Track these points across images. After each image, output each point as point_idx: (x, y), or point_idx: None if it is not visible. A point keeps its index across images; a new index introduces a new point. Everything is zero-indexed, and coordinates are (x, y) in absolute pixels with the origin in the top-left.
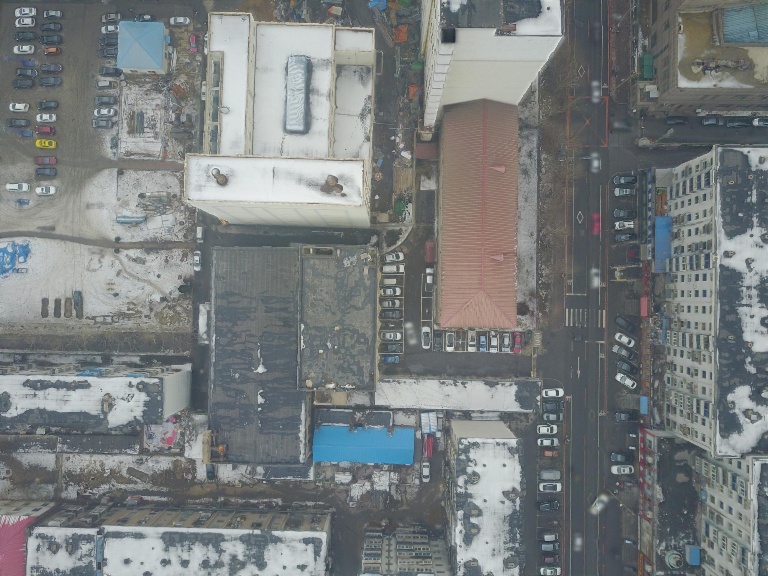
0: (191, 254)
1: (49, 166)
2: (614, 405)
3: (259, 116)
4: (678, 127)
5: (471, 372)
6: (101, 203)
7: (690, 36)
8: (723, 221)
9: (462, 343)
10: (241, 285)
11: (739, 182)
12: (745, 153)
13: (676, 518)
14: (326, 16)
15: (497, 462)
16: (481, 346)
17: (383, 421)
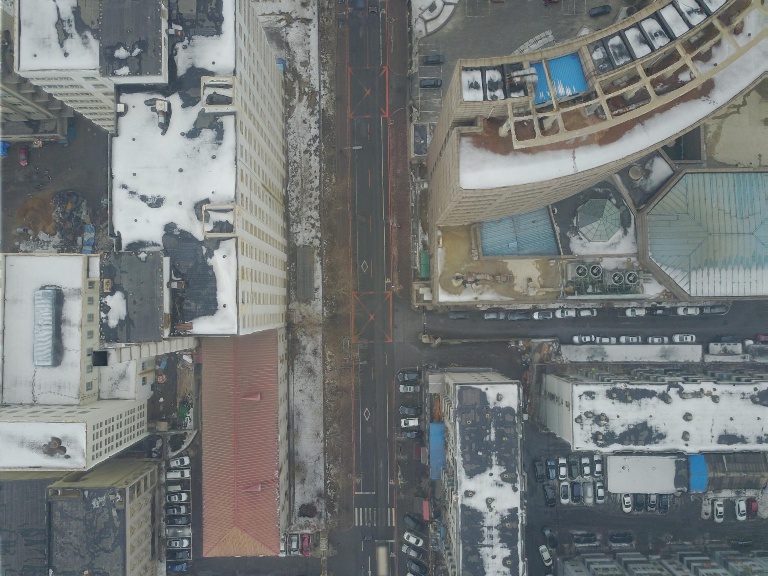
0: None
1: None
2: None
3: (9, 349)
4: (461, 321)
5: None
6: None
7: (450, 249)
8: (463, 460)
9: None
10: (0, 518)
11: (478, 420)
12: (483, 390)
13: None
14: (106, 217)
15: None
16: None
17: None
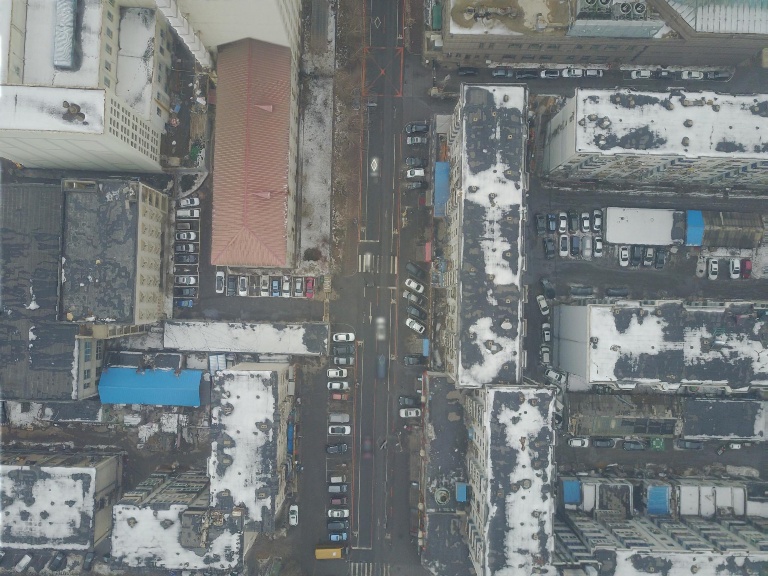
0: None
1: None
2: (403, 350)
3: (30, 53)
4: (470, 78)
5: (265, 317)
6: None
7: None
8: (468, 157)
9: (256, 288)
10: (15, 222)
11: (484, 119)
12: (491, 91)
13: (447, 456)
14: None
15: (250, 394)
16: (274, 291)
17: (172, 363)
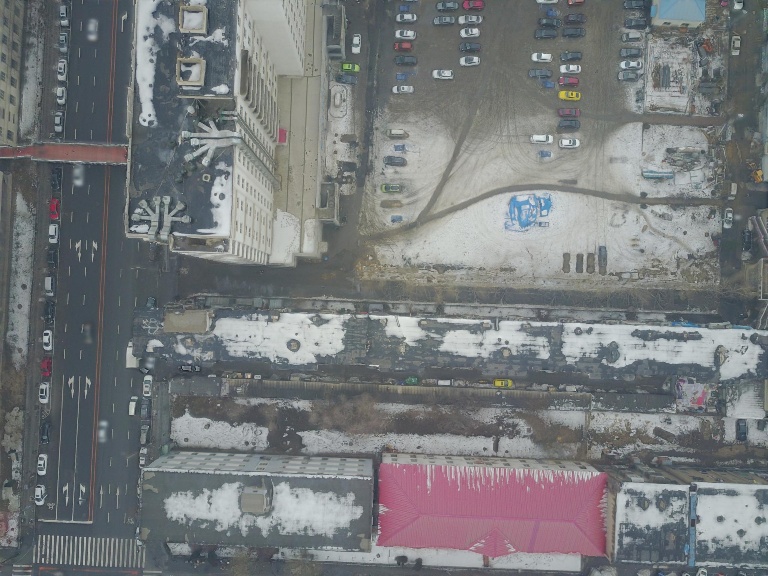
0: (718, 211)
1: (572, 118)
2: None
3: None
4: None
5: None
6: (625, 157)
7: None
8: None
9: None
10: None
11: None
12: None
13: None
14: None
15: None
16: None
17: None
